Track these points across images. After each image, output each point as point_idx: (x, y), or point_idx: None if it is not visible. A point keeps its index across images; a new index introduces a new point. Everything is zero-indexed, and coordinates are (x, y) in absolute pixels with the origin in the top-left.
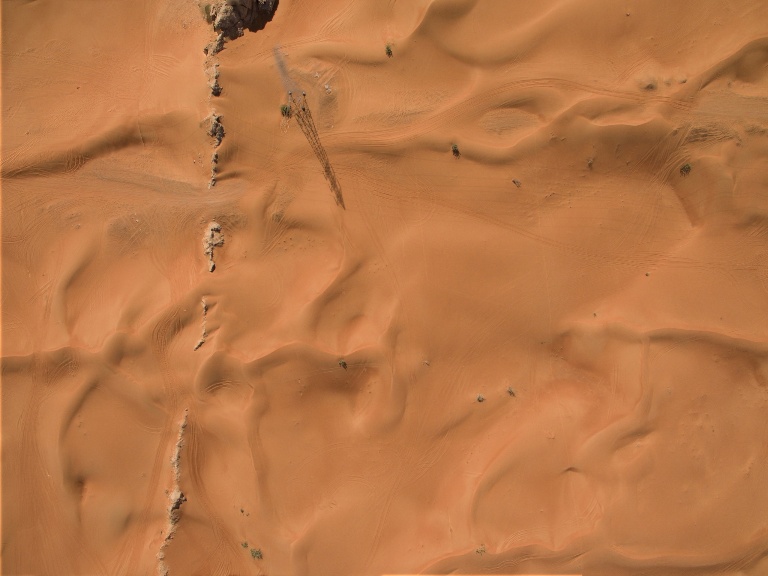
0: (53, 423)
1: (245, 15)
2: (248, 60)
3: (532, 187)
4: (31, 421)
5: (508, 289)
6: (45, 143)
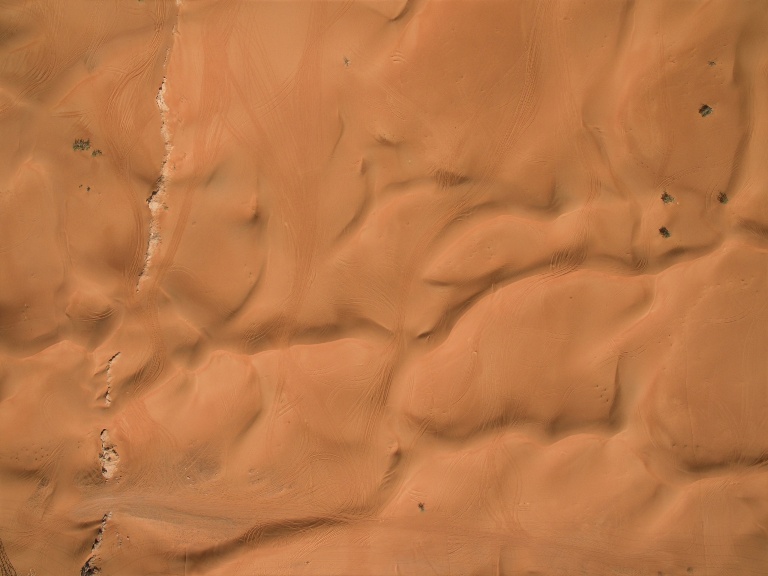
0: (276, 277)
1: None
2: None
3: None
4: (302, 278)
5: None
6: (286, 554)
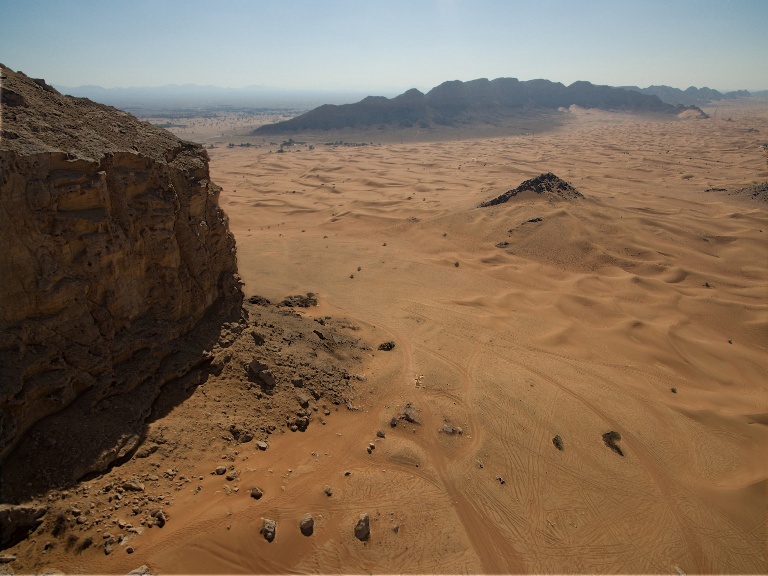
0: None
1: None
2: None
3: None
4: None
5: None
6: None
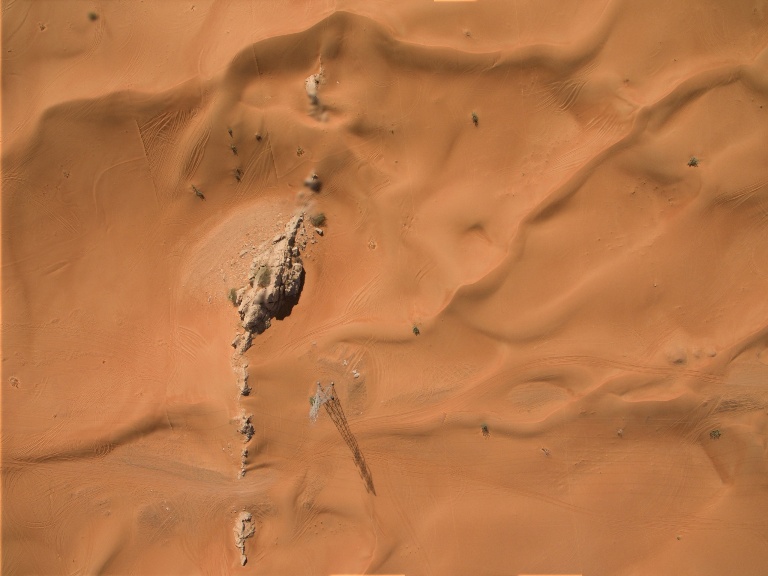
0: None
1: (272, 307)
2: (276, 353)
3: (562, 456)
4: None
5: (540, 561)
6: (73, 429)
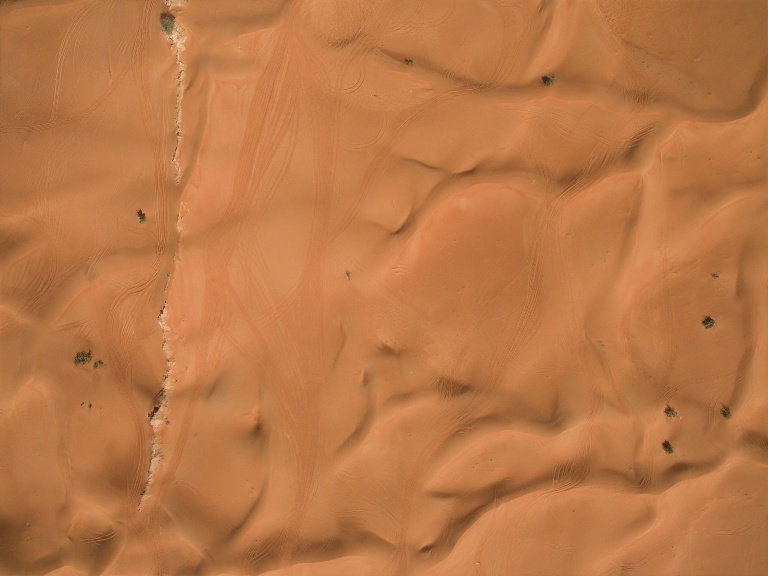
0: (278, 493)
1: None
2: None
3: None
4: (304, 492)
5: None
6: None
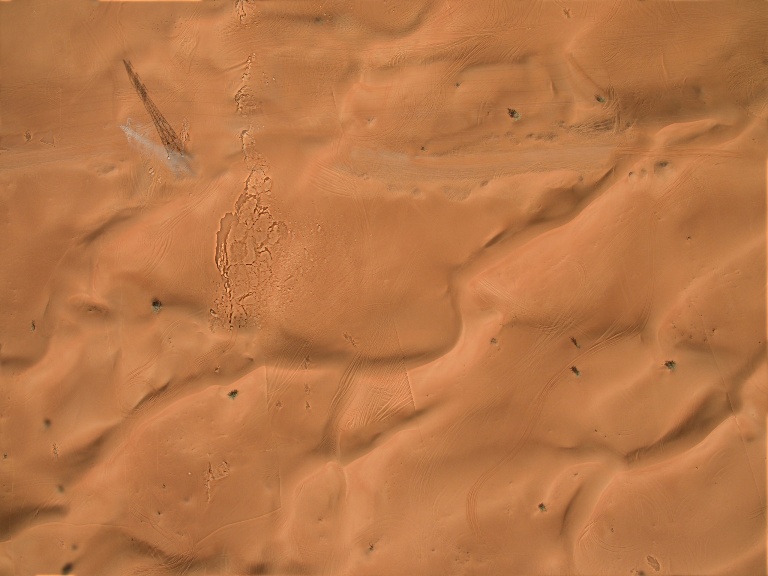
0: None
1: None
2: (225, 178)
3: None
4: None
5: None
6: (434, 75)
